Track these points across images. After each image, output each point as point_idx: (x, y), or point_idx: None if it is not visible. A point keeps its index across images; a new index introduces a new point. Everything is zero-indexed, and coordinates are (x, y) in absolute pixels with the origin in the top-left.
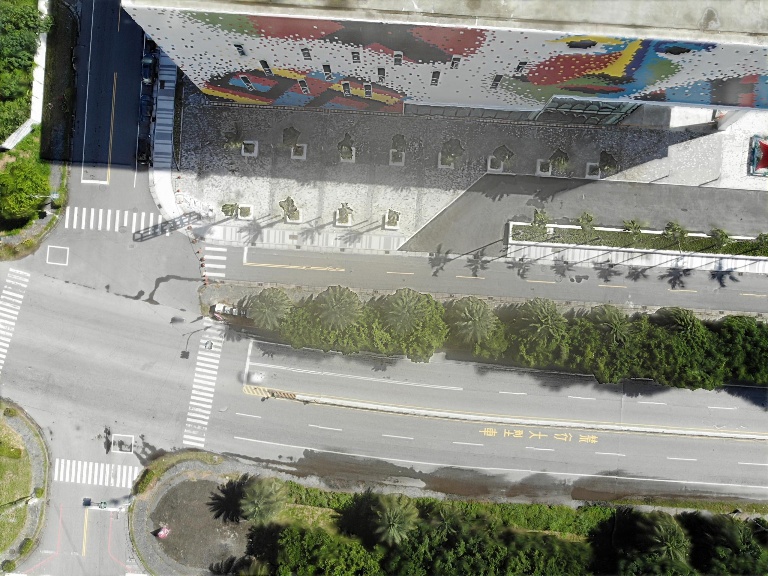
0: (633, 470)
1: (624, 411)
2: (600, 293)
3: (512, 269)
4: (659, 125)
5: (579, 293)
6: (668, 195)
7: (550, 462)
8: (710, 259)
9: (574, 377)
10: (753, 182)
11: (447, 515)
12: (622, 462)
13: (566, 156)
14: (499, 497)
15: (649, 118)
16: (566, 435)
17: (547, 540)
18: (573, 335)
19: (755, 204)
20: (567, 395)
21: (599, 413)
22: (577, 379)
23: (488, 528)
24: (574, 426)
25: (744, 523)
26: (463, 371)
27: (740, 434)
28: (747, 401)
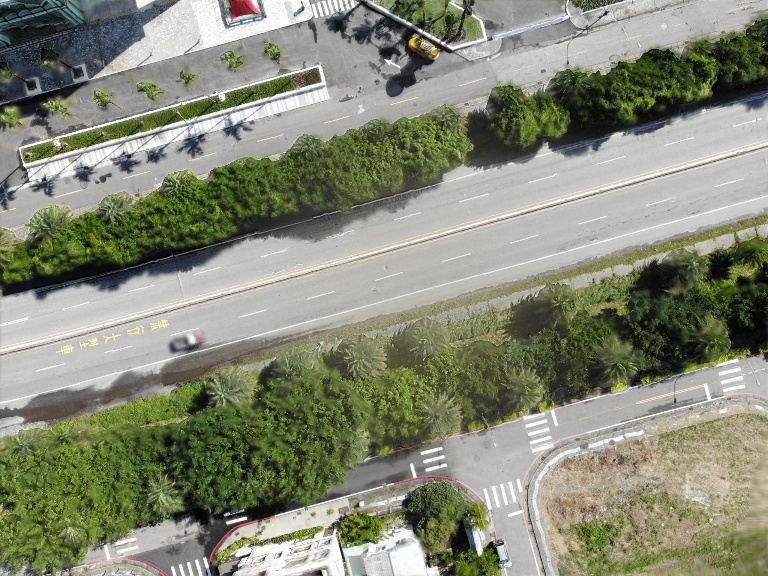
0: (211, 340)
1: (184, 287)
2: (127, 185)
3: (38, 191)
4: (127, 10)
5: (107, 192)
6: (159, 72)
7: (132, 359)
8: (218, 119)
9: (127, 272)
10: (233, 33)
11: (25, 438)
12: (198, 336)
13: (1, 65)
14: (95, 407)
15: (115, 6)
16: (138, 328)
17: (121, 429)
18: (82, 230)
19: (243, 53)
20: (126, 291)
21: (161, 297)
22: (130, 273)
23: (60, 436)
24: (140, 317)
25: (328, 353)
26: (23, 301)
27: (297, 272)
28: (295, 239)
